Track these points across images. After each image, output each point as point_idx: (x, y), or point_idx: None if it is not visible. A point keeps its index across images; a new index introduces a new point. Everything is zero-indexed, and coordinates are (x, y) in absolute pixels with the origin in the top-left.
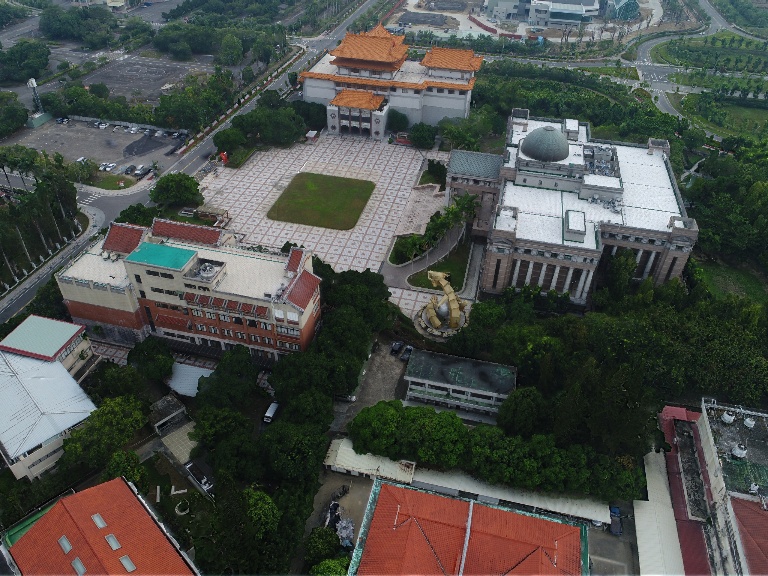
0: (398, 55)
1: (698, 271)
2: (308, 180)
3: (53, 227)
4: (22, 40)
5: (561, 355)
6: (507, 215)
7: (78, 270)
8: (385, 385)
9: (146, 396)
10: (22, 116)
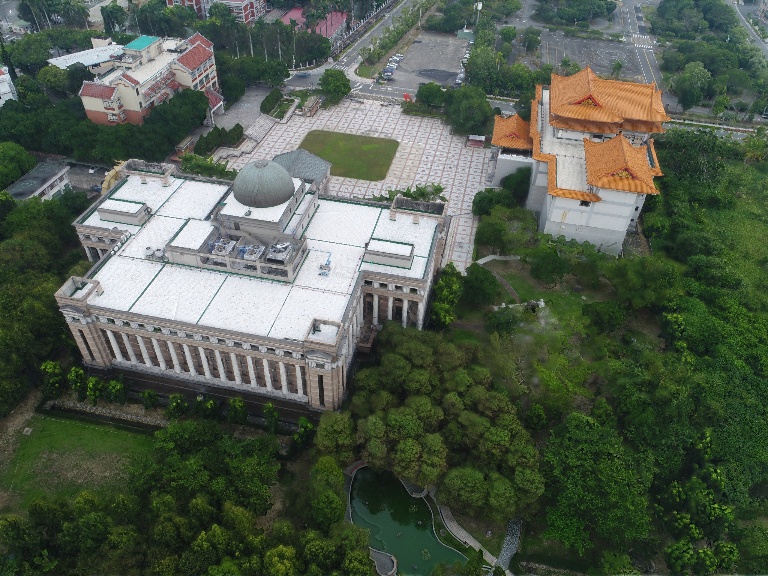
0: (577, 113)
1: (91, 381)
2: (382, 145)
3: (276, 52)
4: (645, 7)
5: (1, 222)
6: (173, 182)
7: (172, 42)
8: (74, 181)
9: (77, 86)
10: (455, 24)
